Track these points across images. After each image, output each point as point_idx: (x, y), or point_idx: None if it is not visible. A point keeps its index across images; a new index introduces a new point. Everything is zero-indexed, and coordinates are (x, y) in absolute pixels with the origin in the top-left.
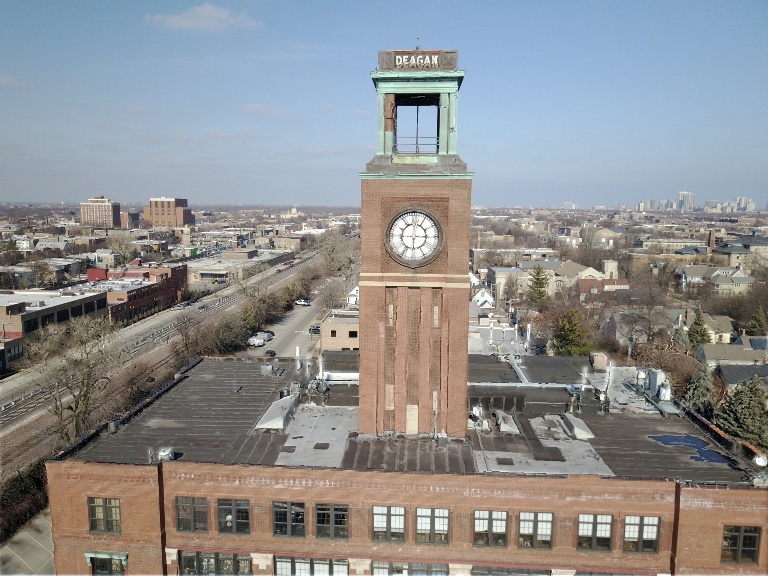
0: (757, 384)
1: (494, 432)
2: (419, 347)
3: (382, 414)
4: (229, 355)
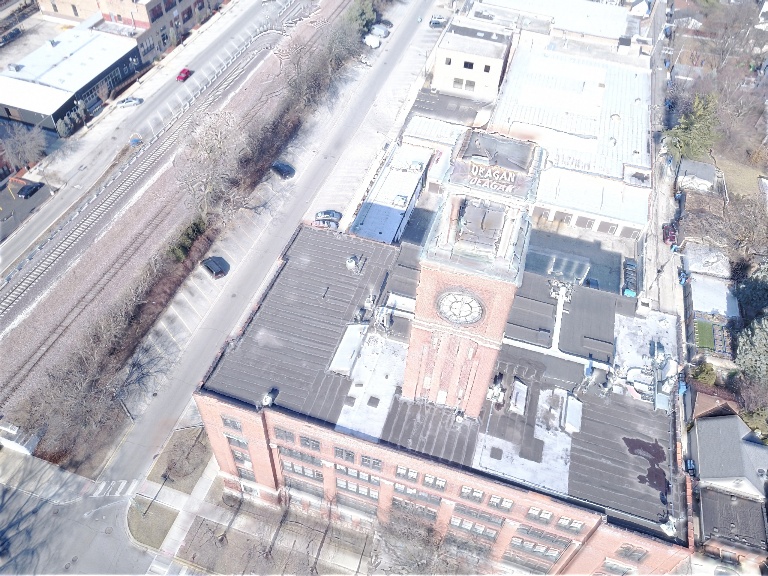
0: None
1: (505, 408)
2: (453, 367)
3: (420, 390)
4: (340, 81)
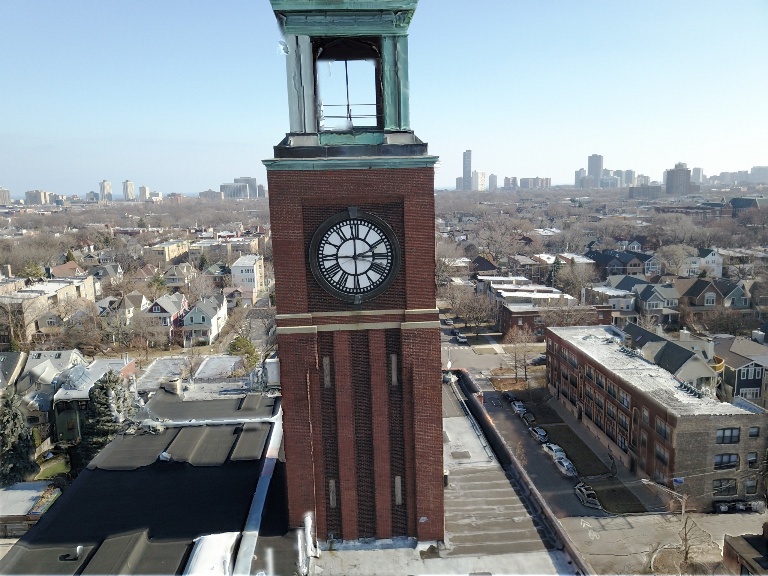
0: (119, 375)
1: None
2: None
3: None
4: None
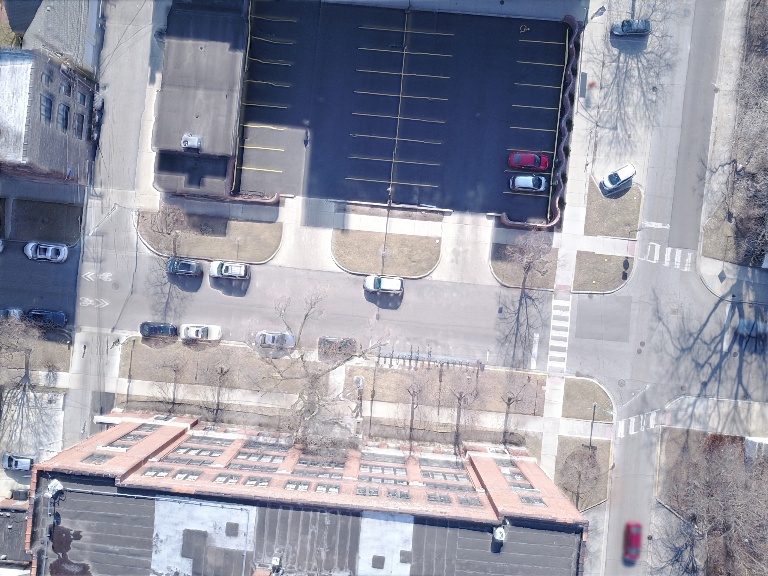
0: None
1: None
2: None
3: None
4: None
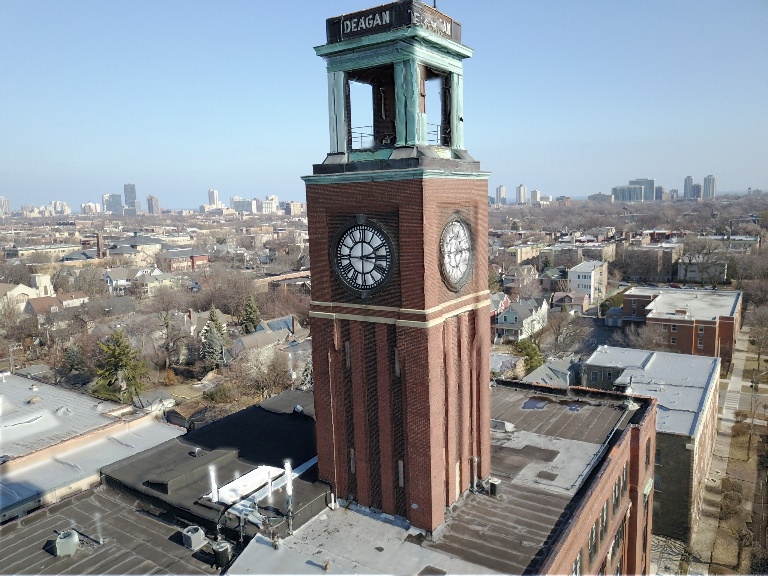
0: None
1: None
2: (461, 389)
3: None
4: None
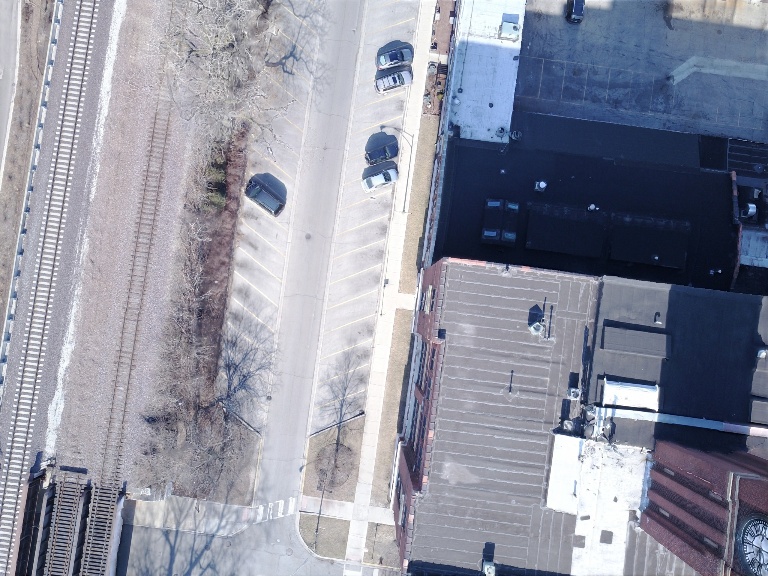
0: None
1: None
2: None
3: None
4: None
